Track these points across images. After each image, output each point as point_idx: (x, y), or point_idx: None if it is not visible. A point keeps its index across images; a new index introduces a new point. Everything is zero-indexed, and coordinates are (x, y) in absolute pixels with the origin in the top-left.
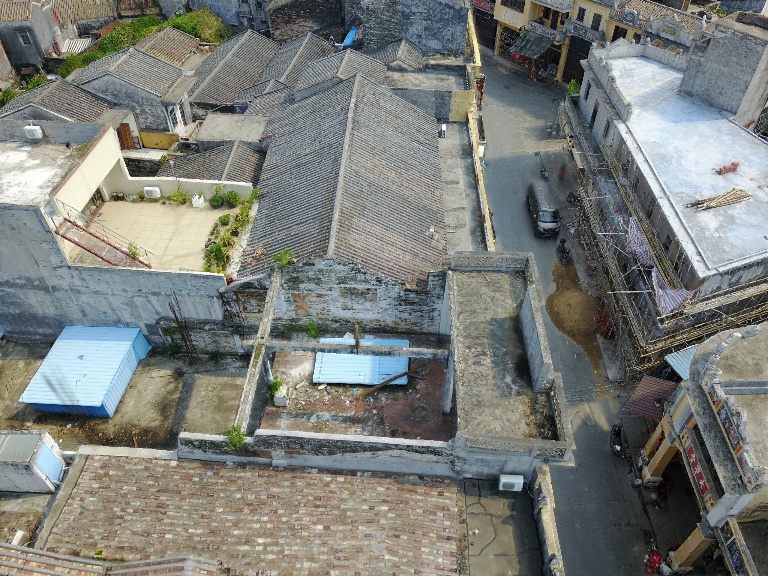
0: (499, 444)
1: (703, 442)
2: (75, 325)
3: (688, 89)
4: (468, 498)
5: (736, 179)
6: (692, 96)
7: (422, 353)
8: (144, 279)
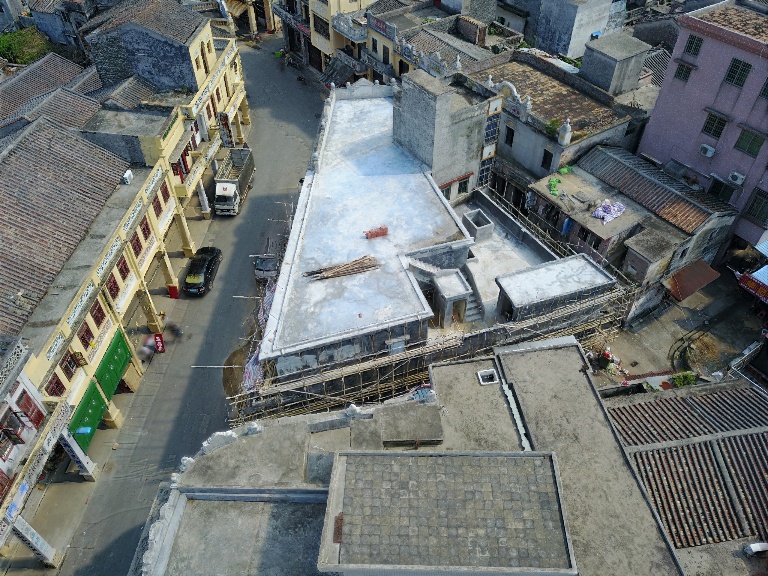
0: None
1: None
2: None
3: (398, 138)
4: None
5: (380, 244)
6: (402, 146)
7: None
8: None
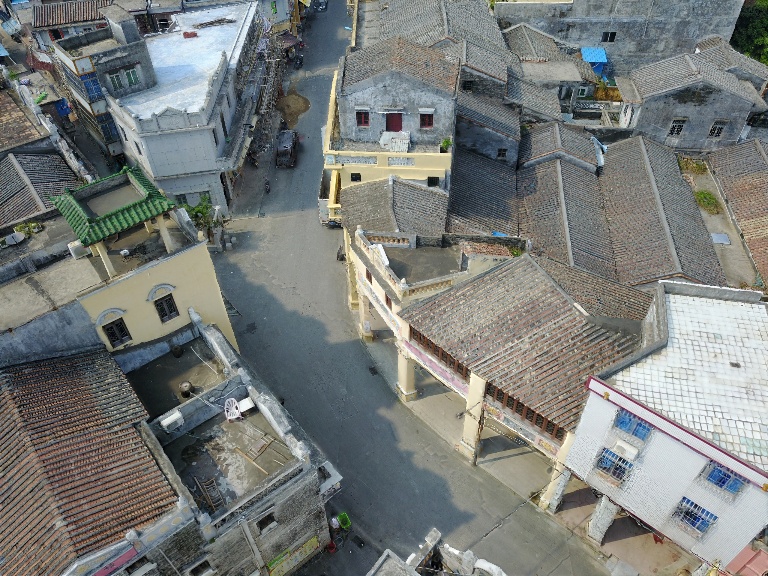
0: None
1: None
2: None
3: None
4: None
5: None
6: None
7: None
8: None
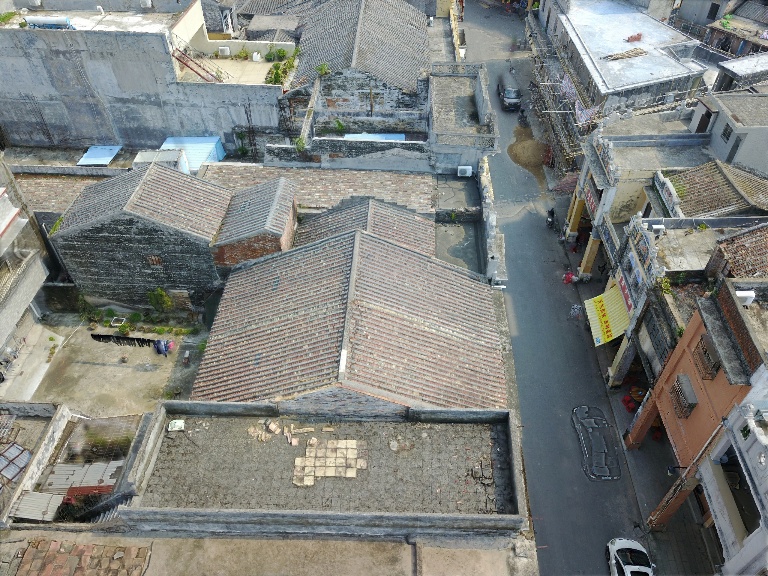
0: (456, 139)
1: (594, 182)
2: (174, 136)
3: None
4: (439, 182)
5: (639, 44)
6: None
7: (412, 113)
8: (228, 92)
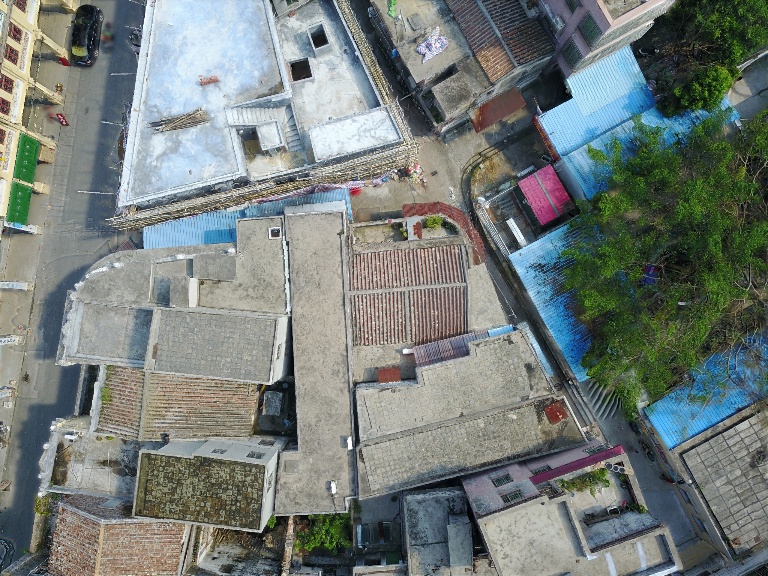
0: None
1: None
2: None
3: None
4: None
5: (212, 94)
6: None
7: None
8: None
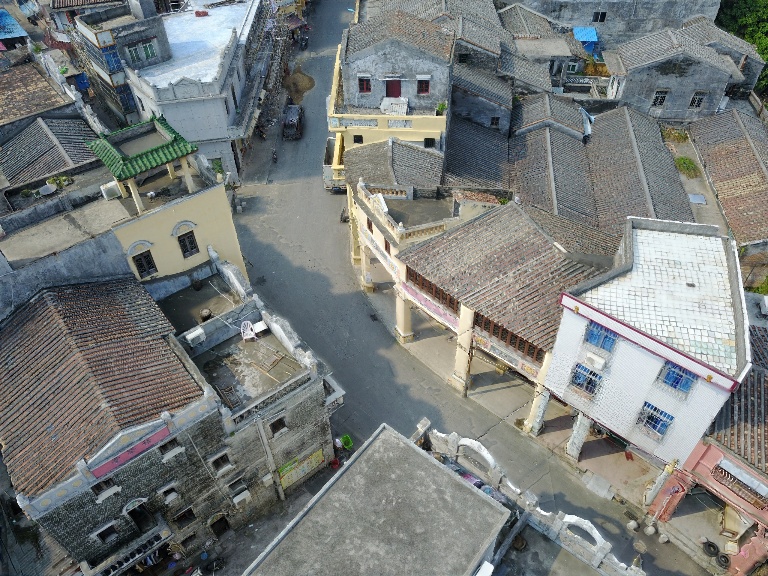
0: None
1: None
2: None
3: None
4: None
5: None
6: None
7: None
8: None
